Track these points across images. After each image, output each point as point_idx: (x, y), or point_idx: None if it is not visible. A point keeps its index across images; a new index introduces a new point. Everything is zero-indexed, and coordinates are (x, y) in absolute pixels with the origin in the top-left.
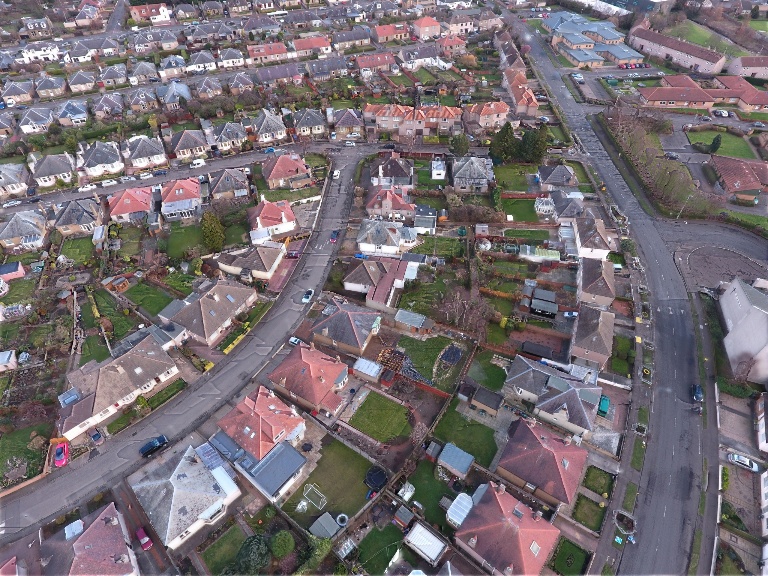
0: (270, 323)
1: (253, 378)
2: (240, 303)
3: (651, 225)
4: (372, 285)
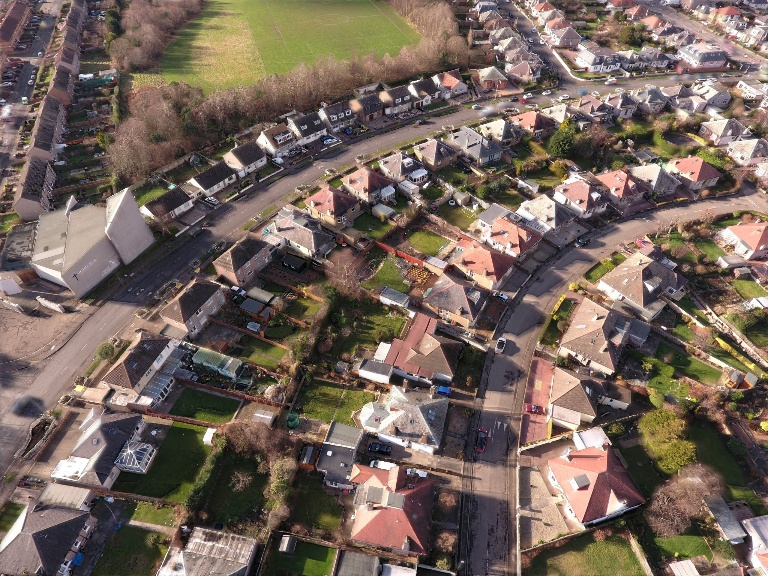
0: (533, 322)
1: (530, 274)
2: (571, 329)
3: (14, 410)
4: (430, 334)
